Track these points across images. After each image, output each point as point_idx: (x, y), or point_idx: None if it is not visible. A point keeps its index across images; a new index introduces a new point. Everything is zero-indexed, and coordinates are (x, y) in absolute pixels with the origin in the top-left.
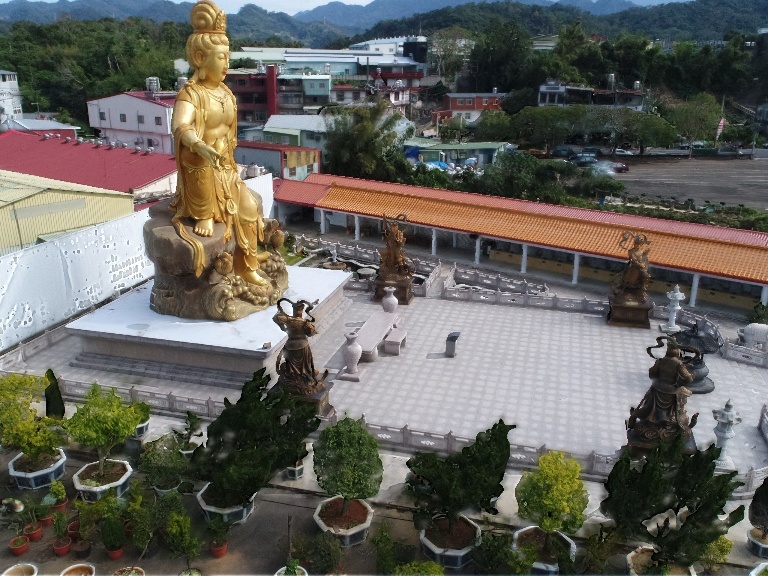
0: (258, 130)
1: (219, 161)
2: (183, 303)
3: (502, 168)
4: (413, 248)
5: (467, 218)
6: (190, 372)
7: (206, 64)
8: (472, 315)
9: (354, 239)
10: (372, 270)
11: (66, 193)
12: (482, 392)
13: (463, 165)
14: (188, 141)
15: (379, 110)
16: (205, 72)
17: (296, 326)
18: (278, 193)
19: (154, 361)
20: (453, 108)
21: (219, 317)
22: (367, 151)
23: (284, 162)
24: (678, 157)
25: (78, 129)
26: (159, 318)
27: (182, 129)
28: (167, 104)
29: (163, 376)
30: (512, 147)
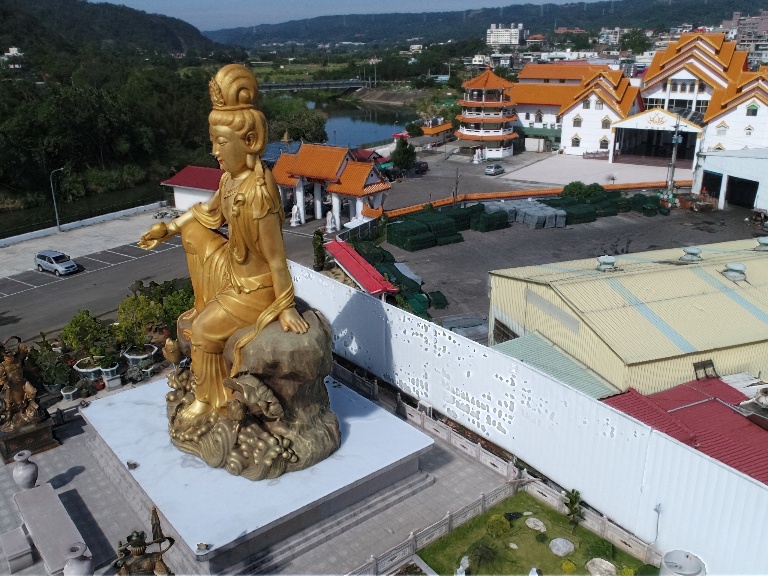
0: None
1: None
2: None
3: None
4: None
5: None
6: None
7: None
8: None
9: None
10: None
11: None
12: None
13: None
14: None
15: None
16: None
17: None
18: None
19: None
20: None
21: None
22: None
23: None
24: None
25: None
26: None
27: None
28: None
29: None
30: None
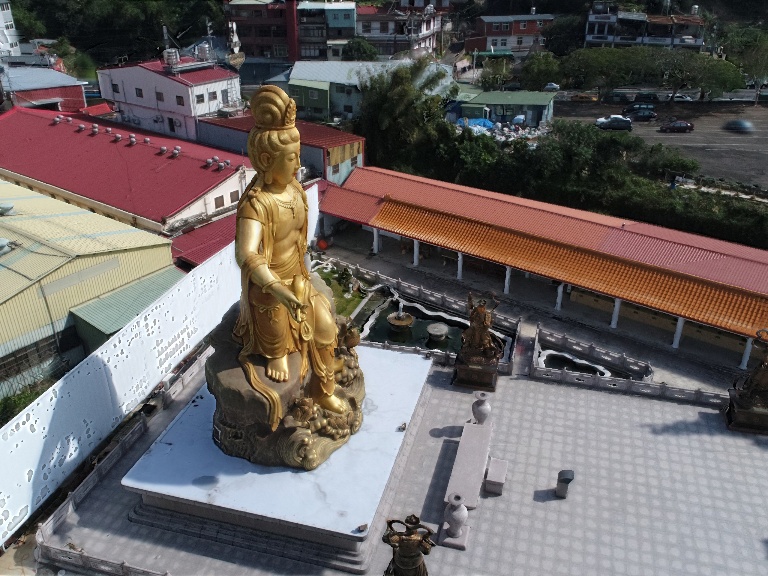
0: (282, 82)
1: (300, 310)
2: (255, 449)
3: (559, 140)
4: (481, 281)
5: (548, 259)
6: (270, 541)
7: (273, 168)
8: (571, 411)
9: (412, 264)
10: (444, 327)
11: (97, 256)
12: (611, 570)
13: (510, 125)
14: (259, 281)
15: (420, 68)
16: (272, 176)
17: (410, 546)
18: (324, 204)
19: (226, 523)
20: (488, 34)
21: (297, 466)
22: (407, 115)
23: (327, 160)
24: (742, 104)
25: (85, 84)
26: (227, 463)
27: (251, 265)
28: (189, 82)
29: (239, 544)
30: (560, 95)
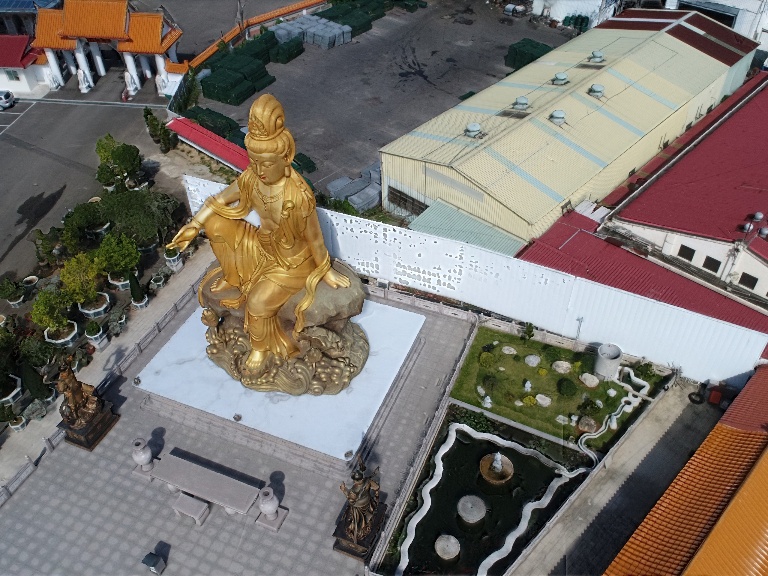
0: None
1: None
2: None
3: None
4: None
5: None
6: None
7: None
8: None
9: None
10: (474, 514)
11: None
12: None
13: None
14: None
15: None
16: None
17: None
18: None
19: None
20: None
21: None
22: None
23: None
24: None
25: None
26: None
27: None
28: None
29: None
30: None
